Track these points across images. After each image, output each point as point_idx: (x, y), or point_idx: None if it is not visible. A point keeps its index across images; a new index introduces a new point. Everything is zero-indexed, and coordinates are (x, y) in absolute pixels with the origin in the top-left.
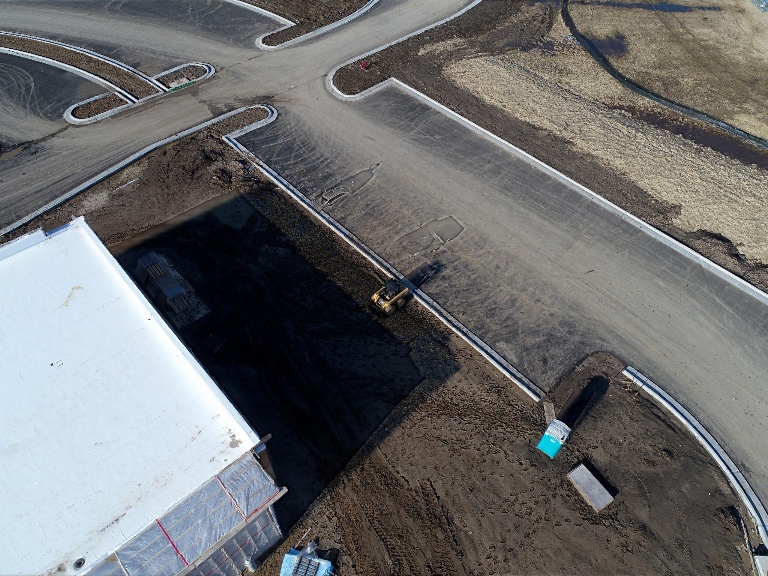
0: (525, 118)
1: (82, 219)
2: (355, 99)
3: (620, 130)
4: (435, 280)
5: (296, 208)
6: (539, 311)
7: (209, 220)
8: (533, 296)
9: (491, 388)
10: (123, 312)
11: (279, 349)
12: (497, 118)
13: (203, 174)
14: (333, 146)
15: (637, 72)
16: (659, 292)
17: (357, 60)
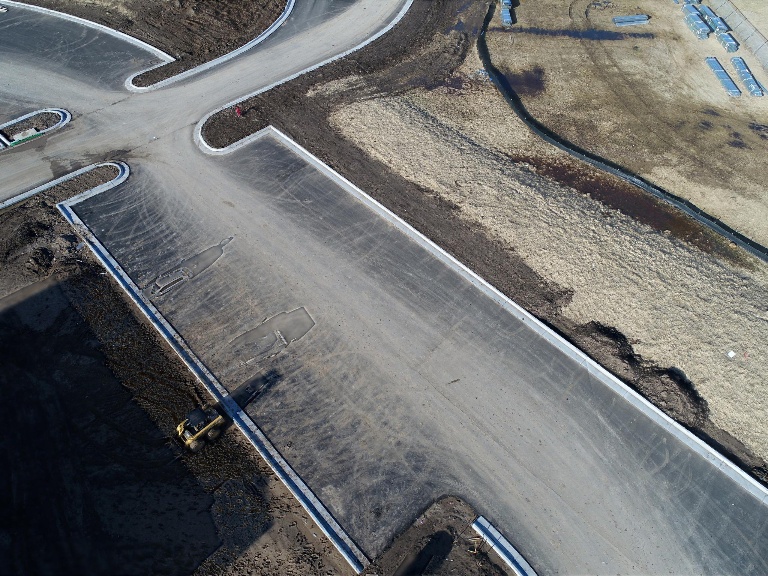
0: (410, 177)
1: None
2: (222, 153)
3: (517, 191)
4: (265, 397)
5: (120, 299)
6: (384, 439)
7: (9, 319)
8: (380, 417)
9: (304, 555)
10: None
11: (47, 505)
12: (379, 177)
13: (19, 255)
14: (184, 215)
15: (550, 115)
16: (532, 409)
17: (235, 104)
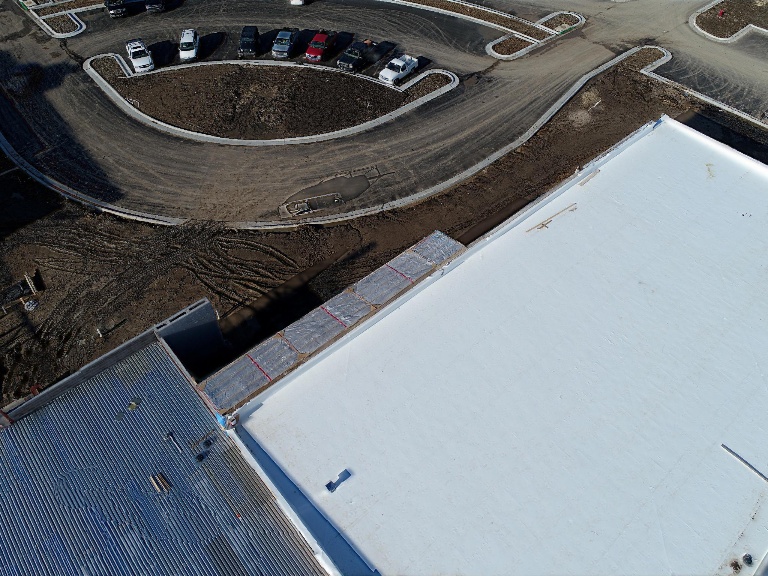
0: None
1: (668, 117)
2: (730, 41)
3: None
4: None
5: (751, 125)
6: None
7: None
8: None
9: None
10: (762, 182)
11: None
12: None
13: (652, 98)
14: (741, 78)
15: None
16: None
17: (707, 10)
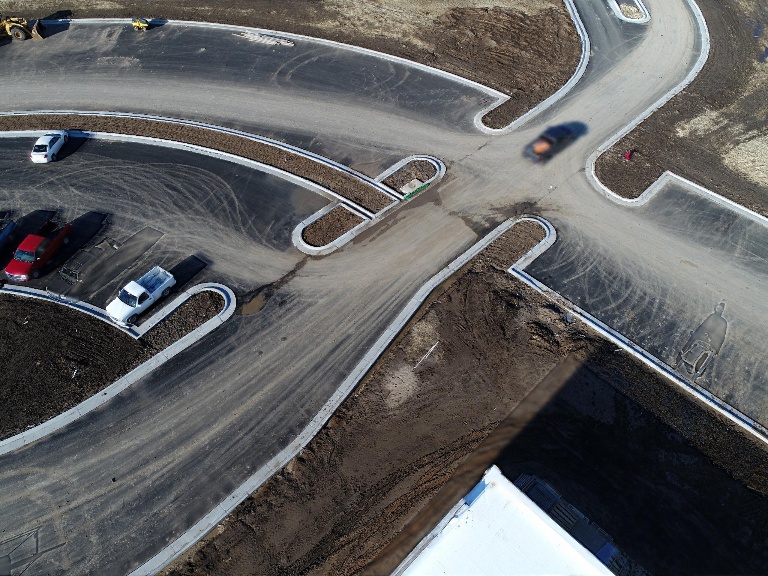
0: None
1: (497, 471)
2: (639, 204)
3: None
4: None
5: (660, 381)
6: None
7: (565, 410)
8: None
9: None
10: None
11: None
12: None
13: (516, 331)
14: (650, 277)
15: None
16: None
17: (611, 146)
